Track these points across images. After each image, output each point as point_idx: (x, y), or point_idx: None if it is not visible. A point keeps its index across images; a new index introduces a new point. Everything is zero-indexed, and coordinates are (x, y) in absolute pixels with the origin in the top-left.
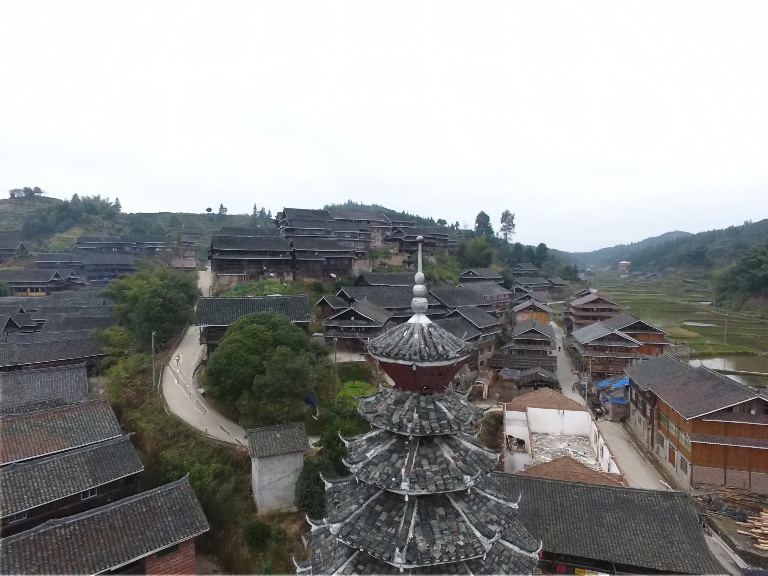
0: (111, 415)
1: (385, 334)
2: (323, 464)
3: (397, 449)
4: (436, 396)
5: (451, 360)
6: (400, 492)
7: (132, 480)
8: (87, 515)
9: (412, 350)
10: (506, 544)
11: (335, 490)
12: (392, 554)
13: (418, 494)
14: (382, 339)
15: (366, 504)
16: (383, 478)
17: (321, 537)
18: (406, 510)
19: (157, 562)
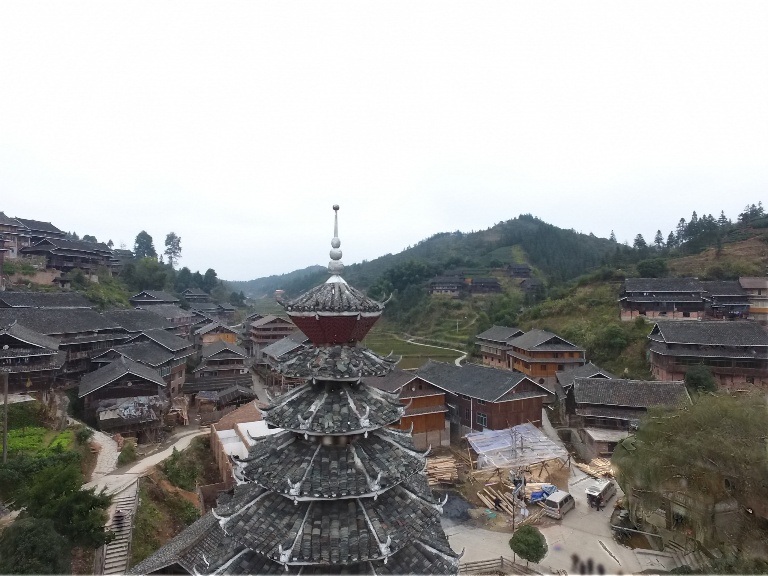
0: None
1: (305, 295)
2: (39, 526)
3: (335, 400)
4: (361, 347)
5: (380, 311)
6: (359, 432)
7: None
8: None
9: (355, 302)
10: None
11: (254, 467)
12: (365, 487)
13: (373, 430)
14: (306, 299)
15: (312, 460)
16: (338, 425)
17: (240, 524)
18: (356, 451)
19: None
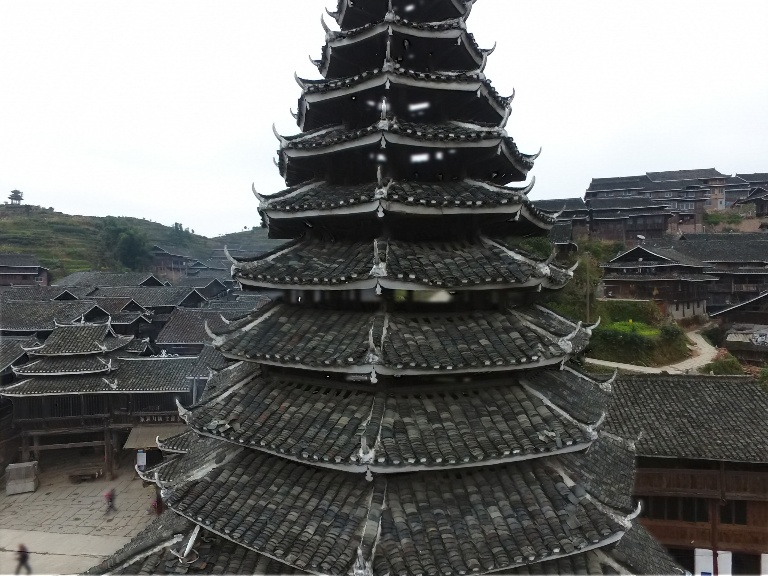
0: None
1: None
2: None
3: None
4: None
5: None
6: None
7: None
8: None
9: None
10: (466, 126)
11: None
12: None
13: (341, 45)
14: None
15: None
16: None
17: None
18: None
19: None
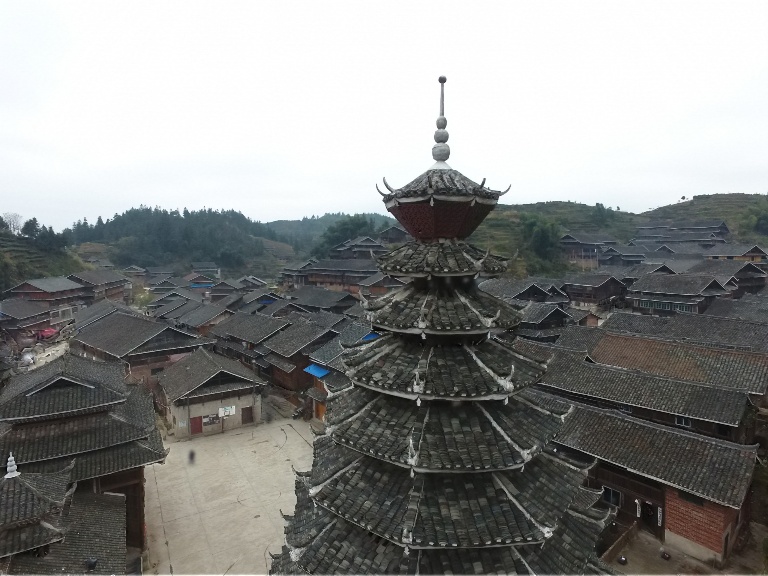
0: (765, 372)
1: None
2: None
3: None
4: None
5: None
6: None
7: (725, 431)
8: (642, 423)
9: None
10: None
11: None
12: None
13: None
14: None
15: None
16: None
17: None
18: None
19: (678, 501)
